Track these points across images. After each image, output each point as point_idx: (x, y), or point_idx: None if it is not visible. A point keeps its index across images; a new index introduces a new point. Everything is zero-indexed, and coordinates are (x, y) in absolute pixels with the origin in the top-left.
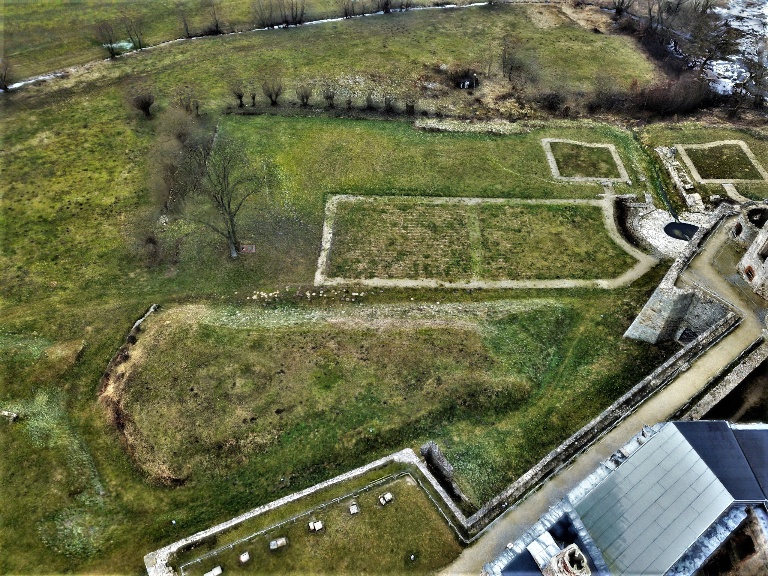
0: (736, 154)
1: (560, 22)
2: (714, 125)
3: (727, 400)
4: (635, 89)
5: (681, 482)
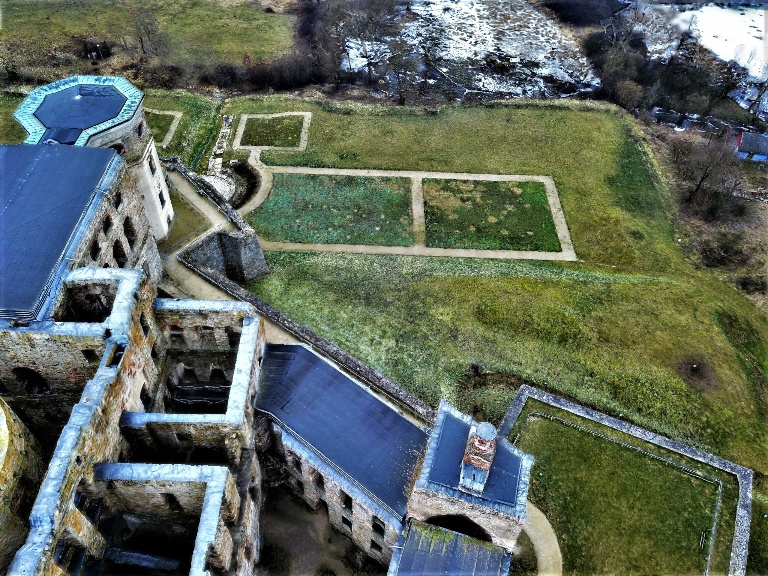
0: (293, 124)
1: (242, 1)
2: (299, 98)
3: None
4: (245, 63)
5: None
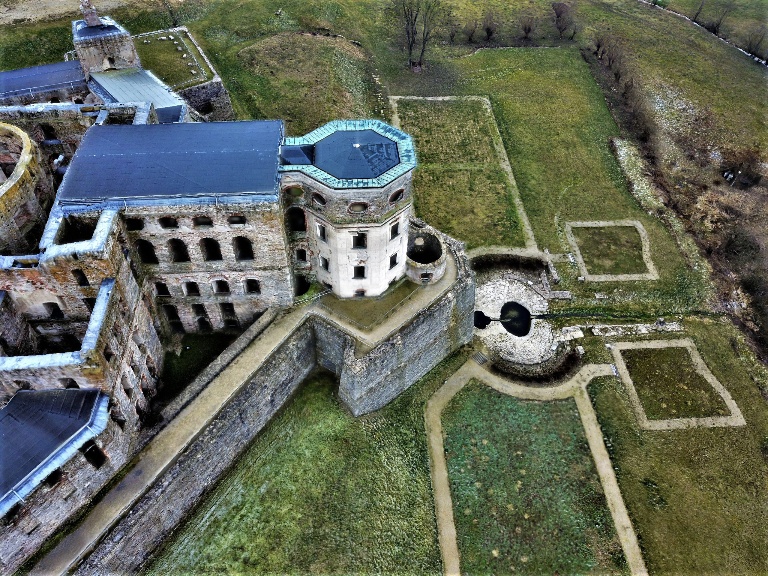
0: (701, 403)
1: None
2: None
3: None
4: None
5: (146, 100)
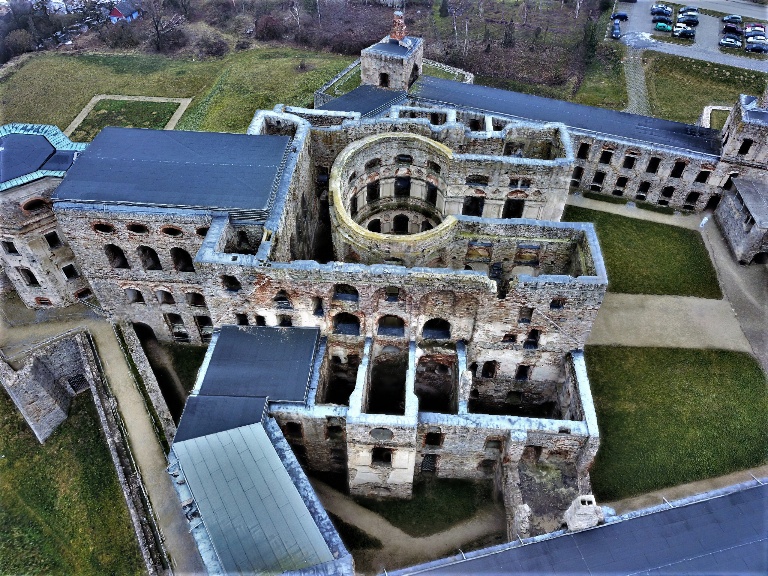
0: None
1: None
2: None
3: (159, 380)
4: None
5: (233, 460)
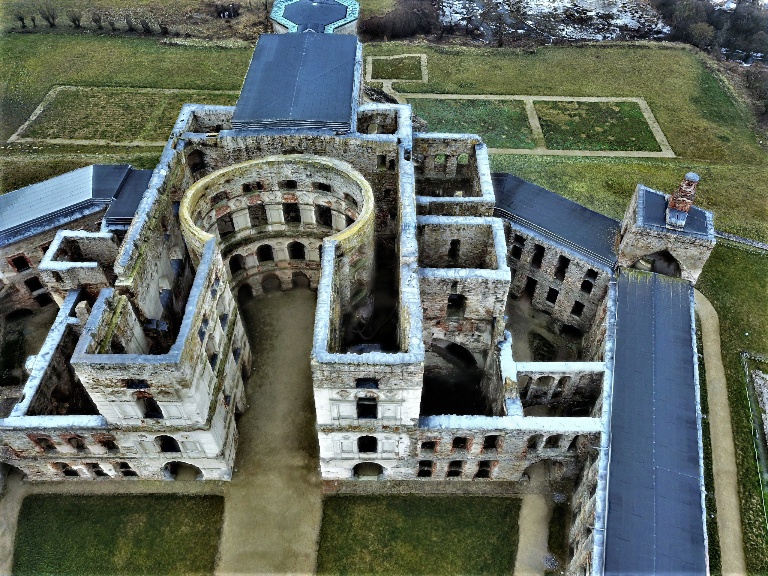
0: (412, 63)
1: None
2: (411, 43)
3: None
4: (360, 17)
5: (66, 190)
